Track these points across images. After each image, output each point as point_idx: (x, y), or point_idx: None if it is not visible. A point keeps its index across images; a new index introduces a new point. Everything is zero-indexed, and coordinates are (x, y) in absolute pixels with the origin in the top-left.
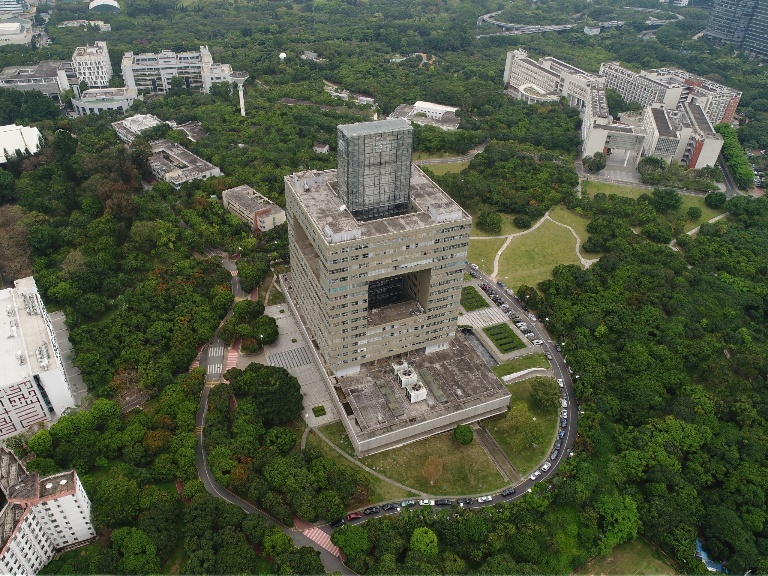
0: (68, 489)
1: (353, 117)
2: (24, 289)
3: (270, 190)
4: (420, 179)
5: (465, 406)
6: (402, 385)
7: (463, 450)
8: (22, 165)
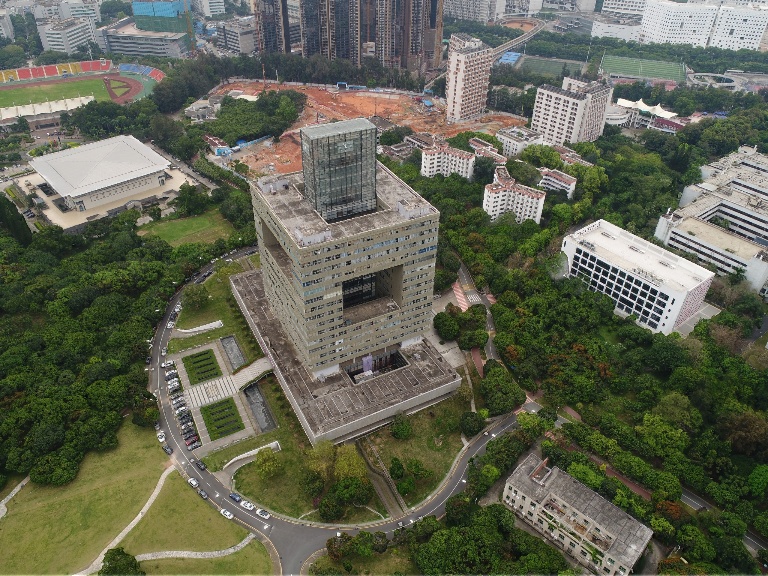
0: (489, 187)
1: None
2: (668, 281)
3: None
4: (290, 223)
5: None
6: None
7: None
8: None
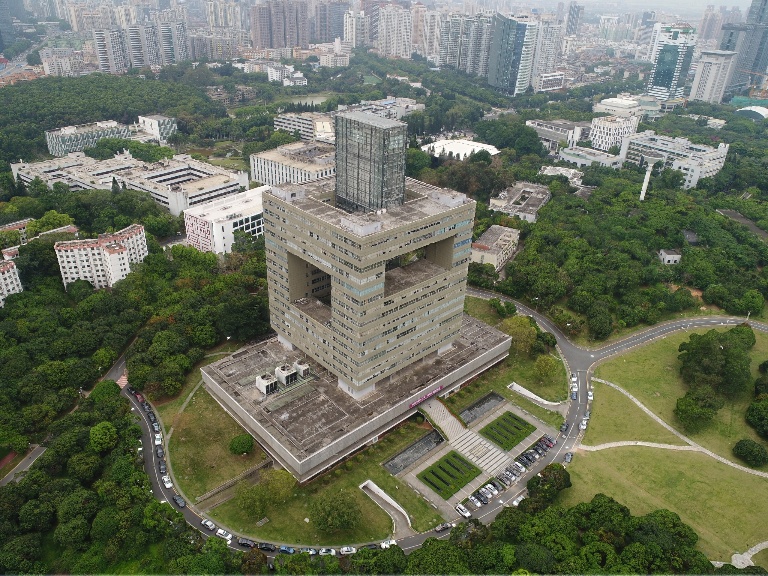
0: (112, 251)
1: (763, 250)
2: None
3: (540, 248)
4: (435, 212)
5: (268, 426)
6: (276, 374)
7: (233, 457)
8: (444, 162)
